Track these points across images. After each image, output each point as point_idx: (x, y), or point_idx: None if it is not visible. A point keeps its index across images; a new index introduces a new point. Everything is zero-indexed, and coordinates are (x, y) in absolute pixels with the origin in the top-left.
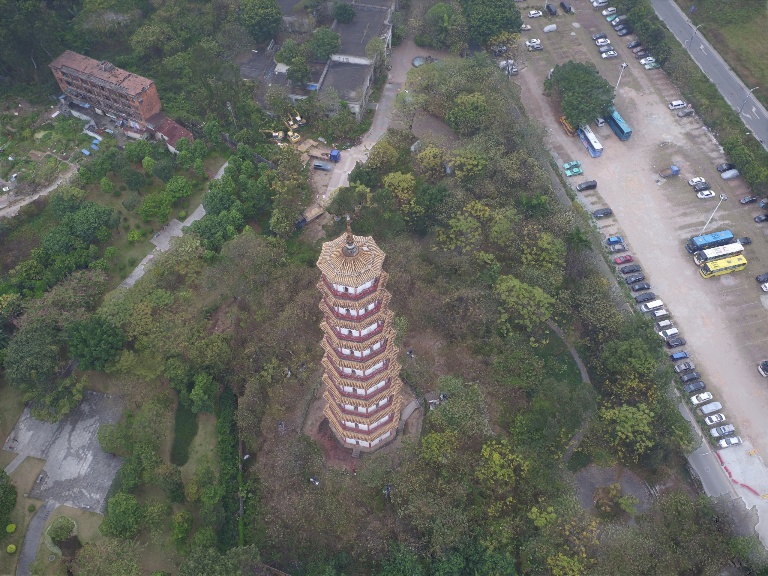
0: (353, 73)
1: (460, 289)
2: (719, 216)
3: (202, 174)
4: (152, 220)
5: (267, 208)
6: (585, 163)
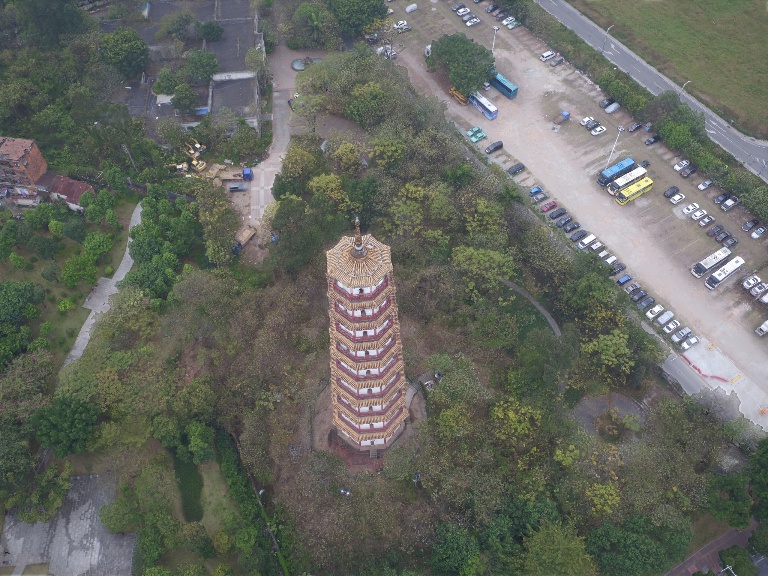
0: (240, 89)
1: (420, 270)
2: (615, 147)
3: (116, 224)
4: (77, 284)
5: (198, 242)
6: (485, 127)
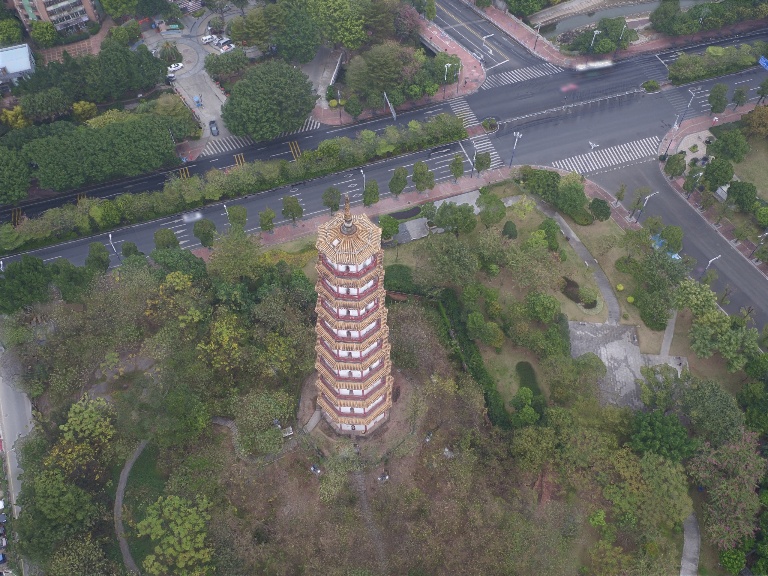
0: None
1: None
2: None
3: None
4: None
5: None
6: None
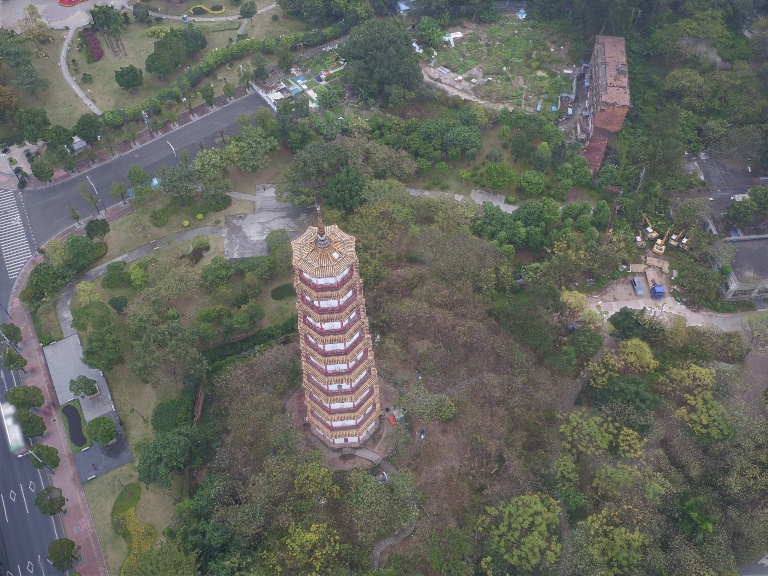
0: None
1: None
2: None
3: (562, 193)
4: None
5: (548, 256)
6: None
